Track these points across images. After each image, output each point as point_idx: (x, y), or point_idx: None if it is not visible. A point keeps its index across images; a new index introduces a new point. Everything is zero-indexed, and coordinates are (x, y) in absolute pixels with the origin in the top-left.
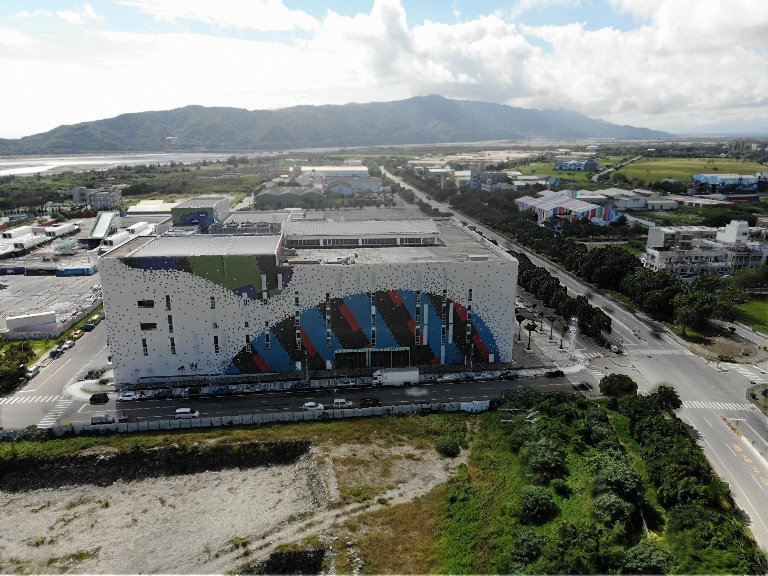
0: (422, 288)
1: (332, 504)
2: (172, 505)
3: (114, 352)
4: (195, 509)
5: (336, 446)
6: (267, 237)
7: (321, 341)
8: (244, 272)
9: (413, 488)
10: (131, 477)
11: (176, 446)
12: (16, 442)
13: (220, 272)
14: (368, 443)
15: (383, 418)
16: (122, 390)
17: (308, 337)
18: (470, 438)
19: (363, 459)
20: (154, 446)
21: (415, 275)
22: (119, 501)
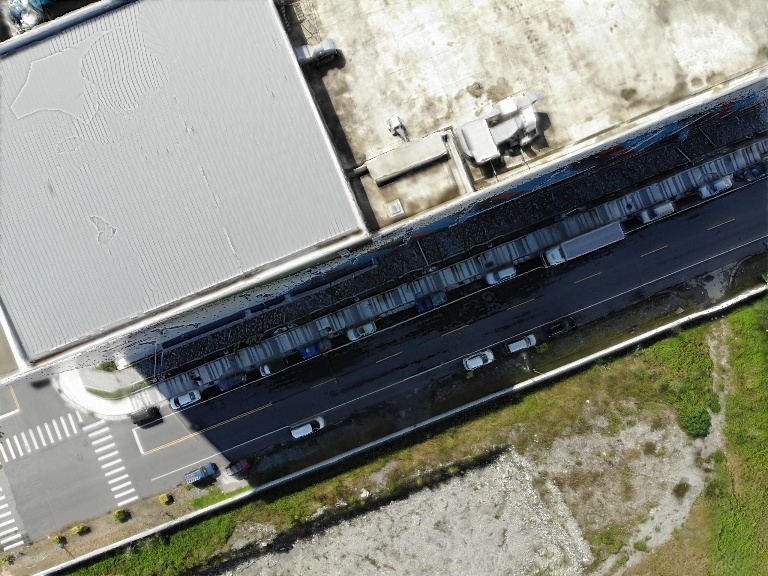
0: (674, 121)
1: (588, 567)
2: (388, 566)
3: (101, 362)
4: (418, 567)
5: (548, 449)
6: (224, 3)
7: (445, 223)
8: (297, 266)
9: (669, 513)
10: (308, 534)
11: (344, 505)
12: (133, 554)
13: (245, 287)
14: (587, 432)
15: (592, 370)
16: (156, 379)
17: (424, 231)
18: (721, 389)
19: (593, 471)
20: (315, 511)
21: (674, 118)
22: (323, 573)
